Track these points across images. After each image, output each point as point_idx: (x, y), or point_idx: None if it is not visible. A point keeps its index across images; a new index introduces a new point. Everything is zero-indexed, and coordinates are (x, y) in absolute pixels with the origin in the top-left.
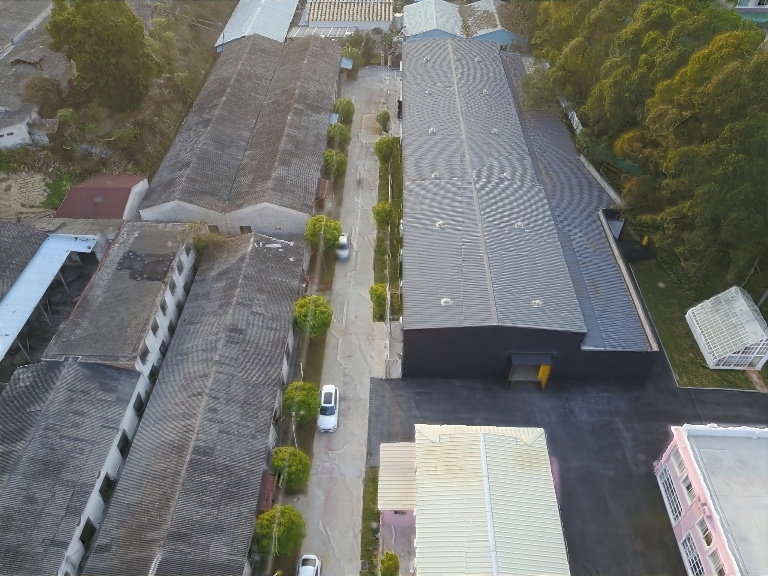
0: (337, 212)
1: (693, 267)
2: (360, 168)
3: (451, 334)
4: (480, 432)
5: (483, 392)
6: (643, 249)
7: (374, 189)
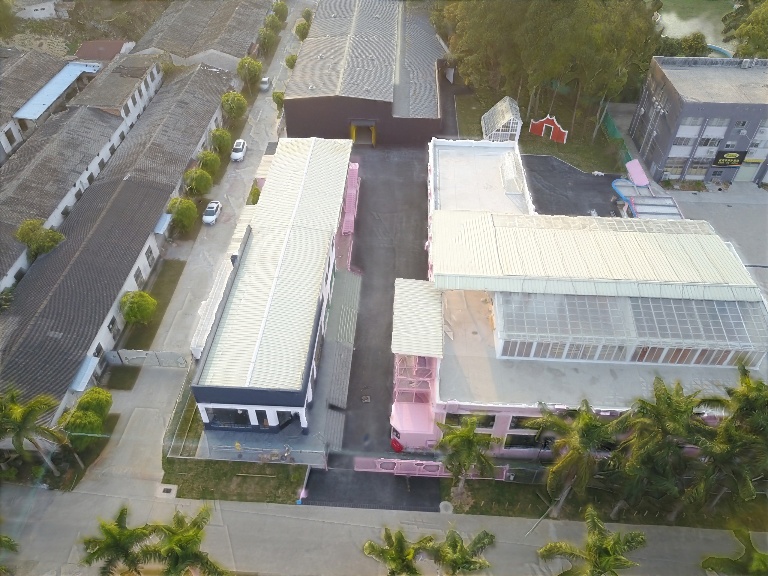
0: (266, 69)
1: (475, 79)
2: (287, 47)
3: (312, 103)
4: (314, 137)
5: None
6: (466, 88)
7: None
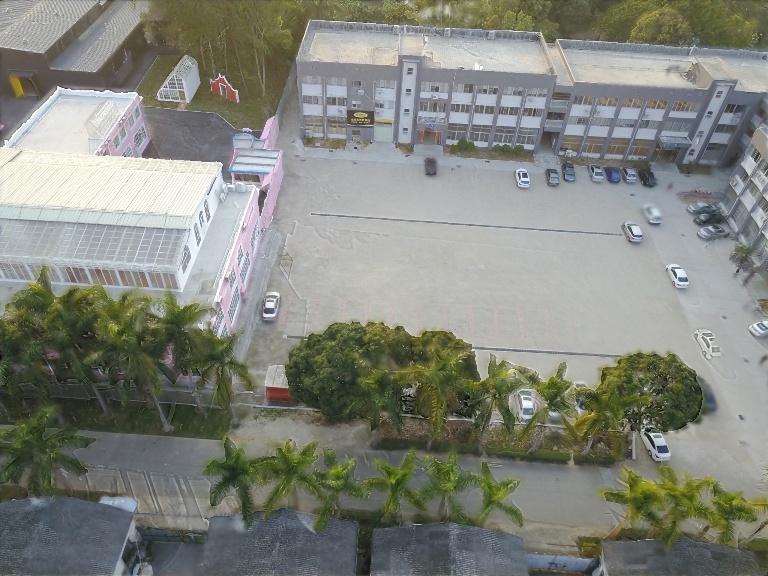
0: None
1: (148, 37)
2: None
3: None
4: None
5: (2, 99)
6: (173, 49)
7: None
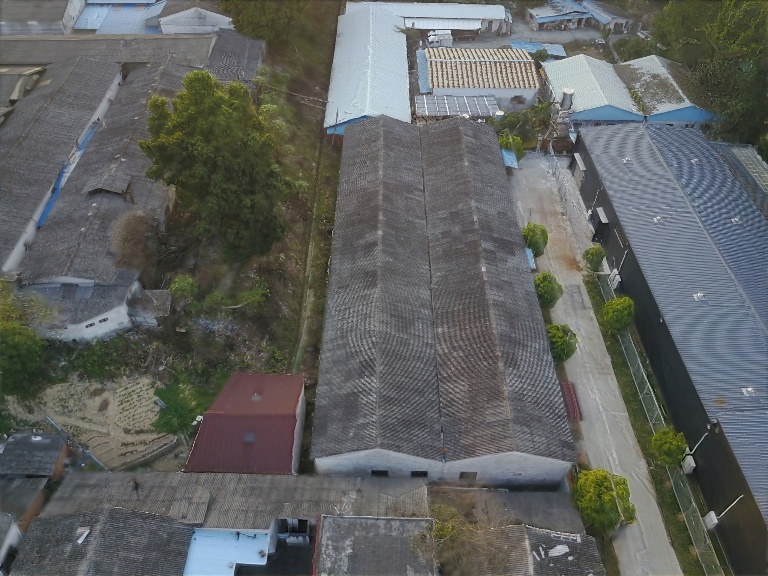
0: None
1: None
2: (575, 333)
3: None
4: None
5: None
6: None
7: (609, 374)
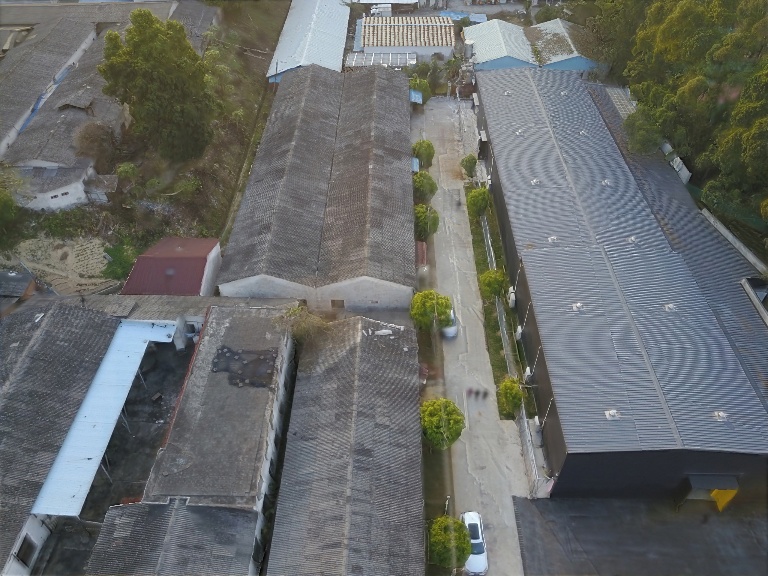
0: (432, 276)
1: None
2: (448, 221)
3: (625, 457)
4: None
5: (649, 516)
6: None
7: (468, 247)
